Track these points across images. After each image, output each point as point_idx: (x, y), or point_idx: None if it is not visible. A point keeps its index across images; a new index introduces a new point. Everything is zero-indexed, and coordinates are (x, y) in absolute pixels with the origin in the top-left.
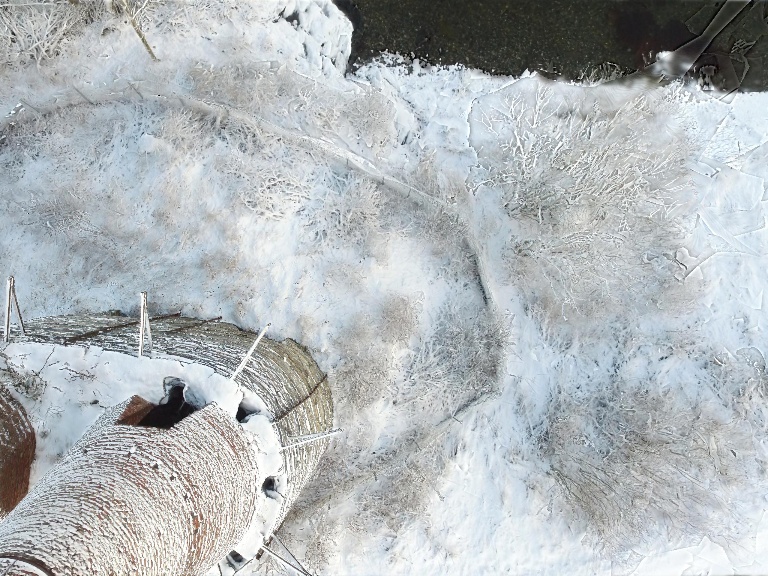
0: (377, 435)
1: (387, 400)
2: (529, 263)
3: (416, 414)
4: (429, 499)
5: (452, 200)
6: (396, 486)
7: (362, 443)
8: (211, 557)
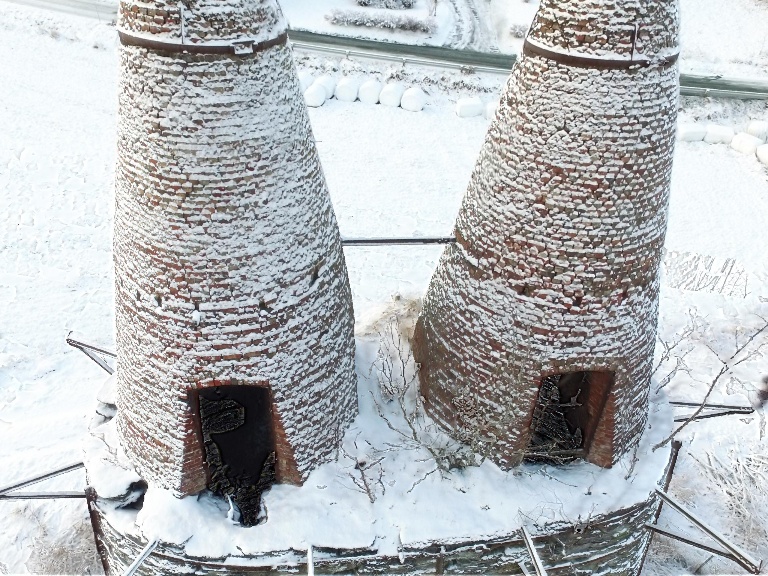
0: None
1: None
2: None
3: None
4: (29, 568)
5: None
6: None
7: None
8: None
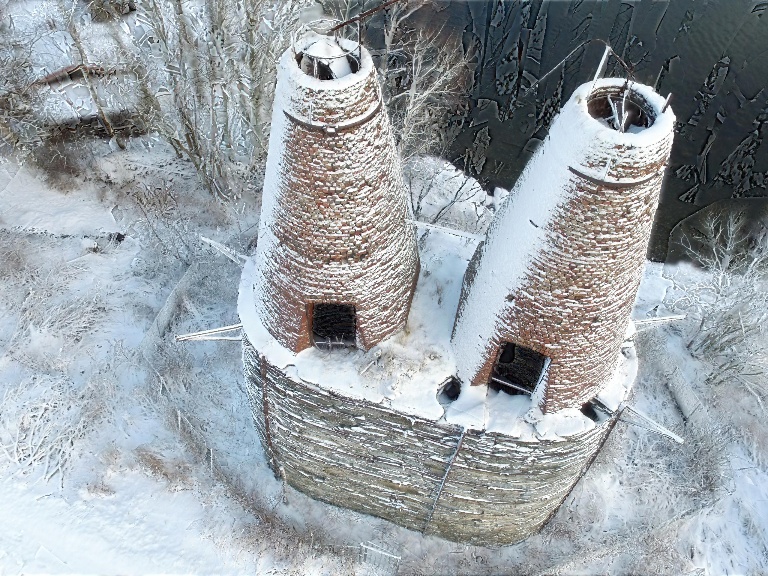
0: (607, 512)
1: (613, 478)
2: (724, 391)
3: (642, 505)
4: None
5: (654, 312)
6: (638, 568)
7: (594, 513)
8: (625, 327)
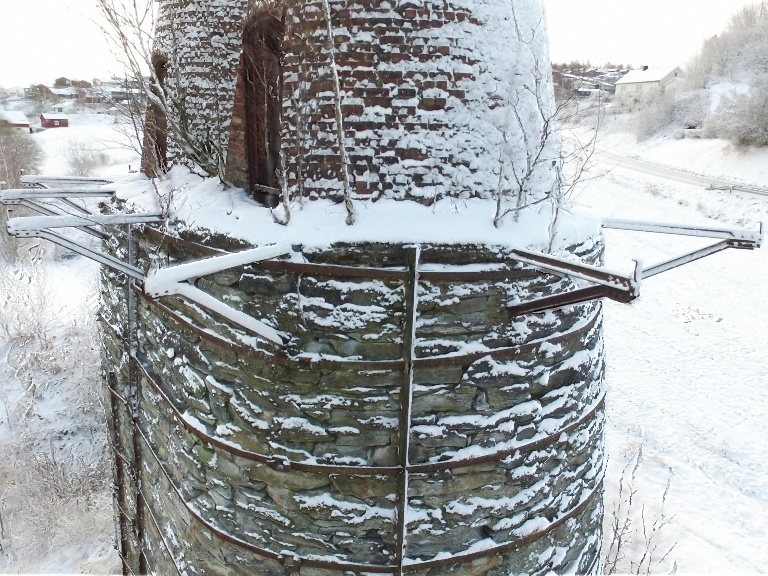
0: None
1: None
2: None
3: None
4: None
5: None
6: None
7: None
8: None
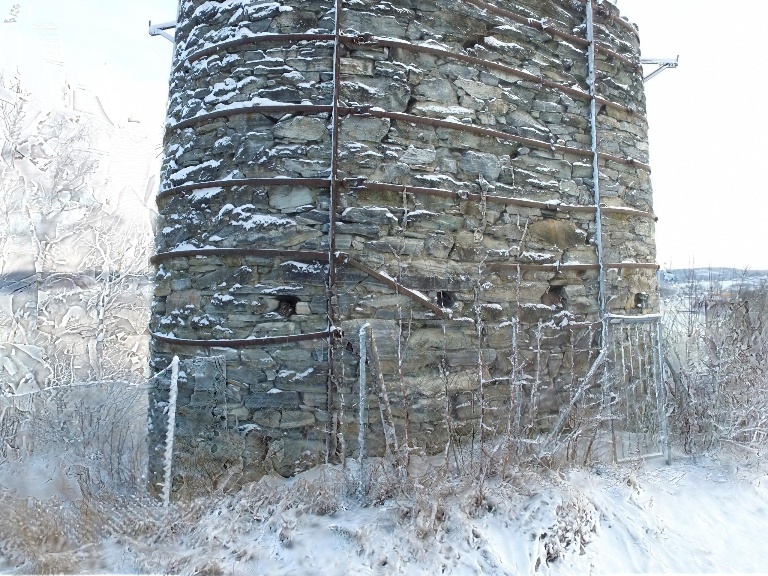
0: None
1: None
2: None
3: None
4: None
5: None
6: None
7: None
8: None
